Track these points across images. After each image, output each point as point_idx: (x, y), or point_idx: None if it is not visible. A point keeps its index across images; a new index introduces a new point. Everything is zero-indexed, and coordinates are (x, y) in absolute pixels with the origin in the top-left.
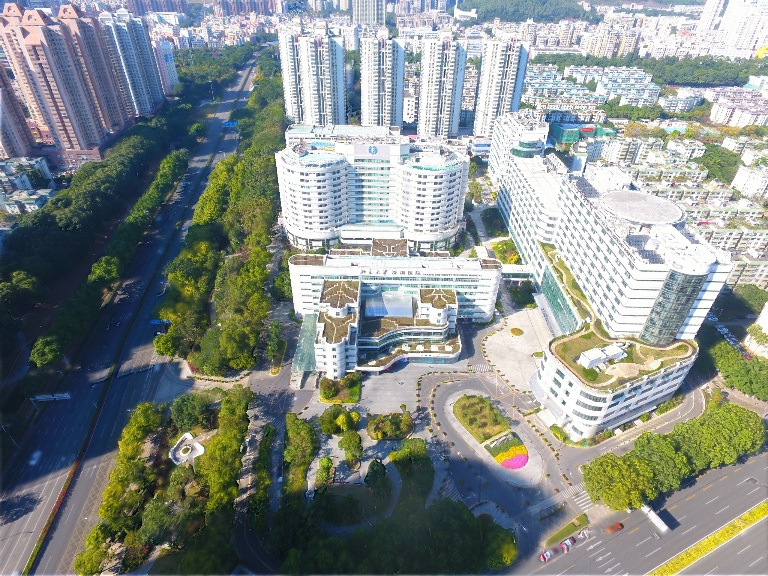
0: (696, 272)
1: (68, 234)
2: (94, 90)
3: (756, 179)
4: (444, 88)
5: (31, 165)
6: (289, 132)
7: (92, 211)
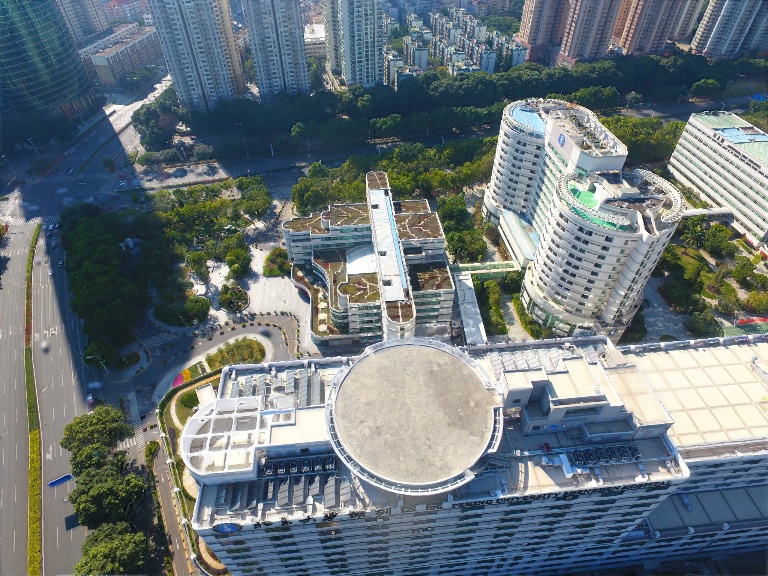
0: (189, 442)
1: (420, 94)
2: (642, 7)
3: None
4: None
5: (512, 50)
6: (697, 116)
7: (465, 92)
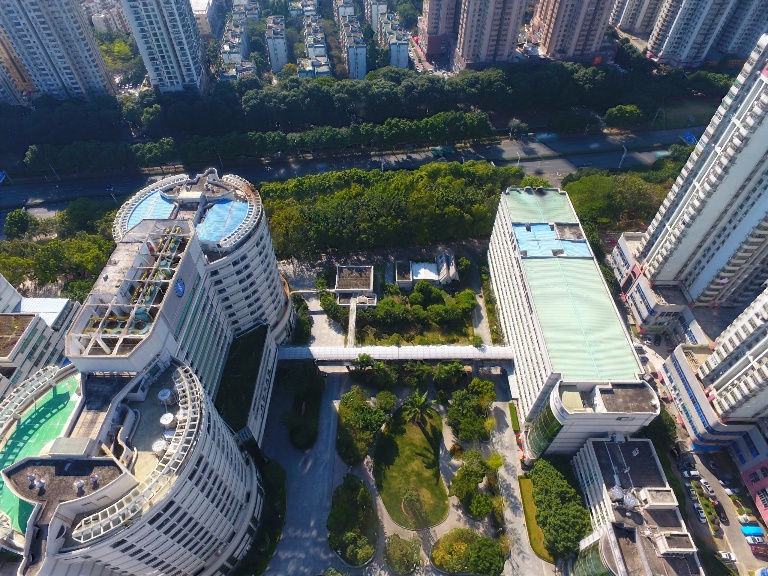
0: None
1: (222, 108)
2: None
3: None
4: None
5: (390, 44)
6: (511, 193)
7: (289, 107)
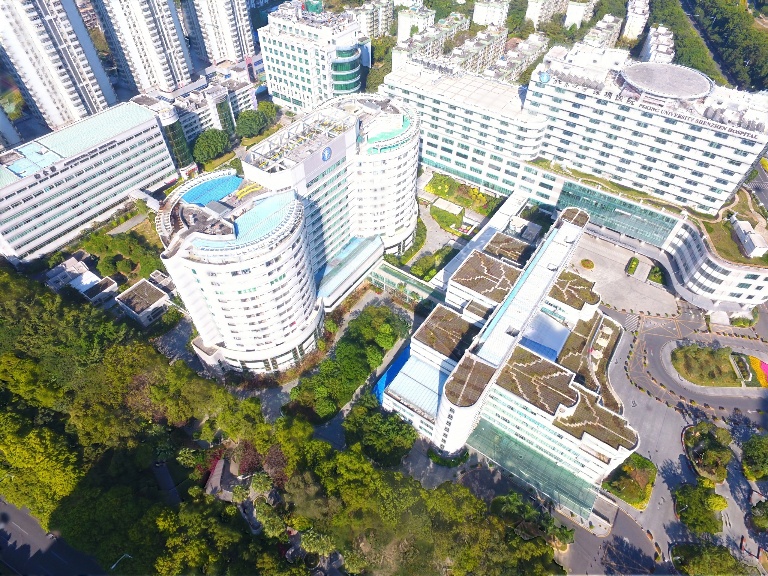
0: None
1: None
2: None
3: (493, 12)
4: (155, 4)
5: None
6: None
7: None
